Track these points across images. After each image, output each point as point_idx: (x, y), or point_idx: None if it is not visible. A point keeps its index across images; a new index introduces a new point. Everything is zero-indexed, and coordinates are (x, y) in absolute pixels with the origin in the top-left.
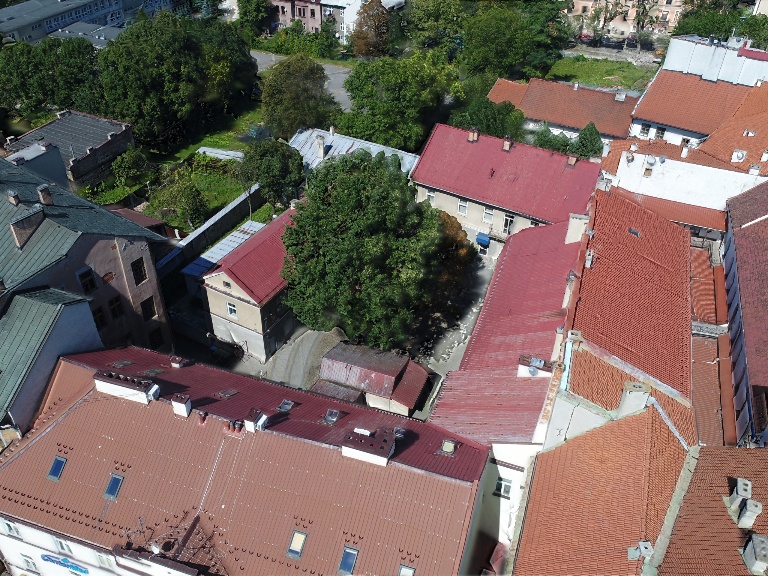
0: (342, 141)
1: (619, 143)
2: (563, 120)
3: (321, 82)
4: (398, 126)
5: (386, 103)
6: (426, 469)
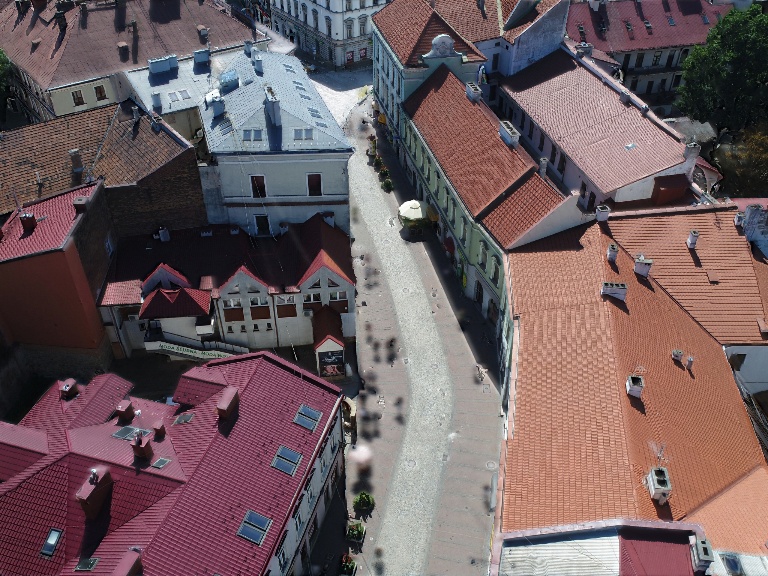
0: None
1: None
2: None
3: None
4: None
5: None
6: (576, 4)
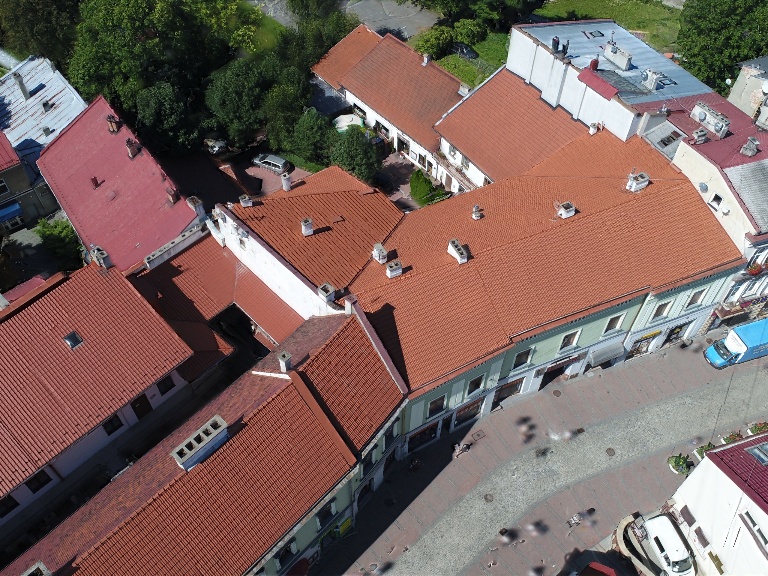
0: (57, 82)
1: (331, 173)
2: (381, 105)
3: (63, 2)
4: (115, 79)
5: (100, 48)
6: None
